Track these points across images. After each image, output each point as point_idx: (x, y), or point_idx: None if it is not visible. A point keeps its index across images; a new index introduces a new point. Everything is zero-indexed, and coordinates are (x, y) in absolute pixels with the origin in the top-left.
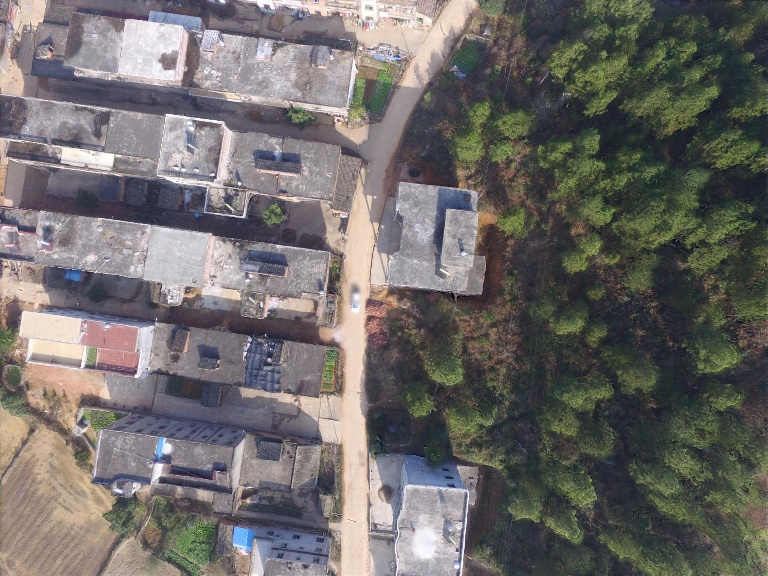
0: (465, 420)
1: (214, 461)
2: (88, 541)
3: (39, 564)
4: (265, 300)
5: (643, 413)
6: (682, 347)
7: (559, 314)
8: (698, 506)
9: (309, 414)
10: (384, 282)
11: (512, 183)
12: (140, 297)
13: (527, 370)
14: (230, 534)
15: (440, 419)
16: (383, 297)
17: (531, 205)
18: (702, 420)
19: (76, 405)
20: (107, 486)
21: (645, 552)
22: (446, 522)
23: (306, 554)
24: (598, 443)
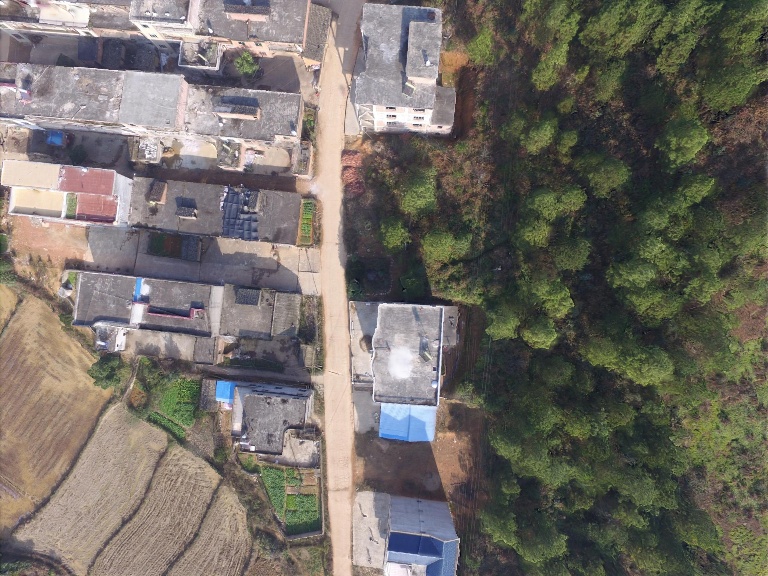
0: (439, 243)
1: (192, 300)
2: (76, 409)
3: (29, 433)
4: (240, 150)
5: (619, 222)
6: (655, 148)
7: (529, 128)
8: (676, 297)
9: (288, 268)
10: (358, 132)
11: (481, 20)
12: (120, 161)
13: (501, 197)
14: (213, 389)
15: (417, 258)
16: (358, 146)
17: (501, 40)
18: (675, 204)
19: (61, 269)
20: (93, 350)
21: (624, 351)
22: (422, 341)
23: (286, 395)
24: (573, 251)
